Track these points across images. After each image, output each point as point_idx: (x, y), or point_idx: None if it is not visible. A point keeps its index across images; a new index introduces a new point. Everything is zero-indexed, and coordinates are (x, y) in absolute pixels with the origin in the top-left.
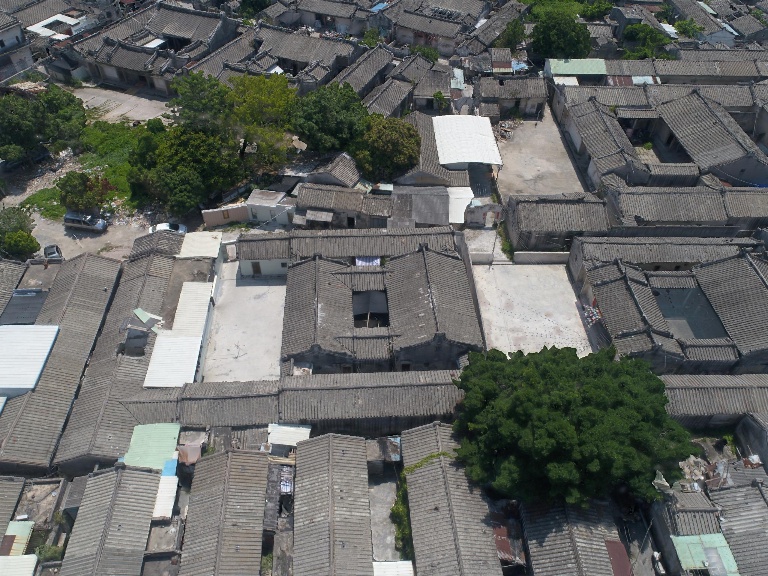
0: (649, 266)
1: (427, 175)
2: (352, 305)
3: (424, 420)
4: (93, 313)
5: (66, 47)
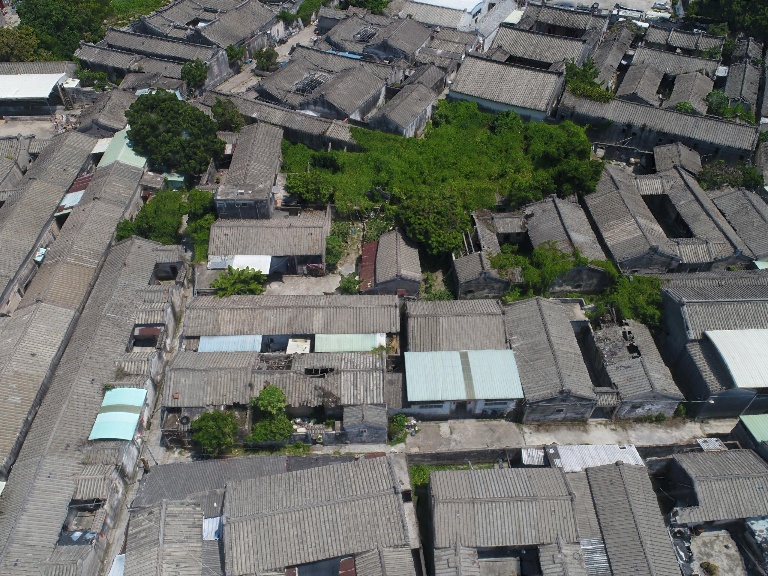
0: None
1: None
2: None
3: None
4: None
5: None
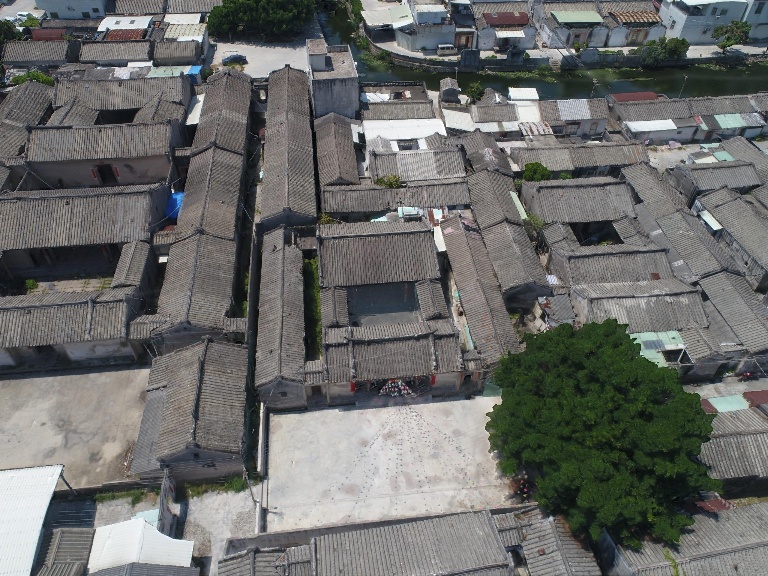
0: None
1: None
2: None
3: None
4: None
5: None
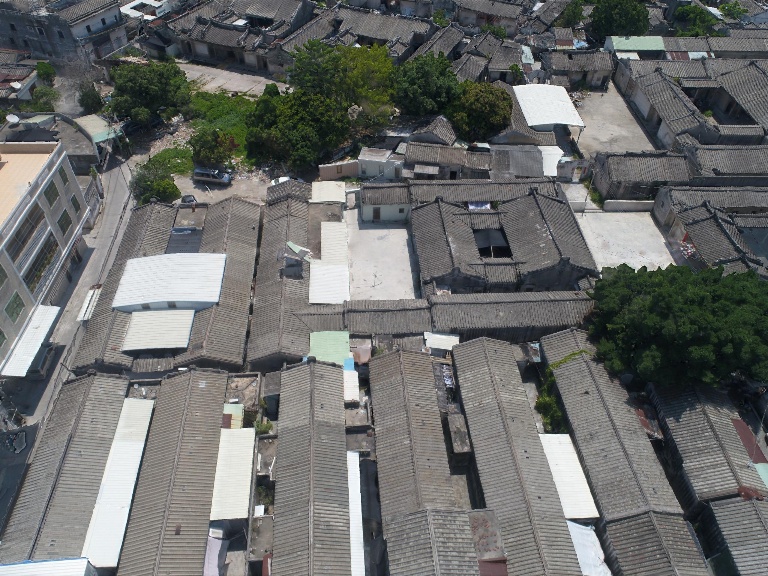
0: (728, 211)
1: (519, 134)
2: (474, 240)
3: (556, 331)
4: (248, 246)
5: (161, 25)
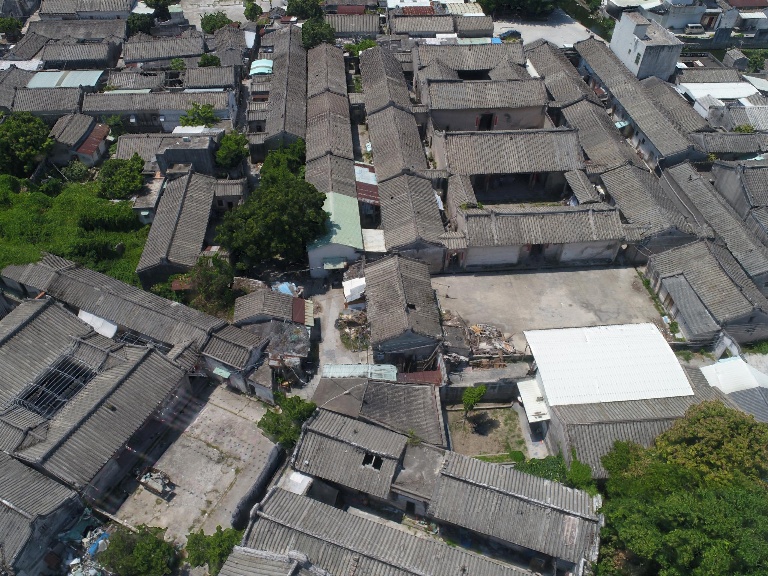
0: None
1: None
2: None
3: None
4: None
5: None
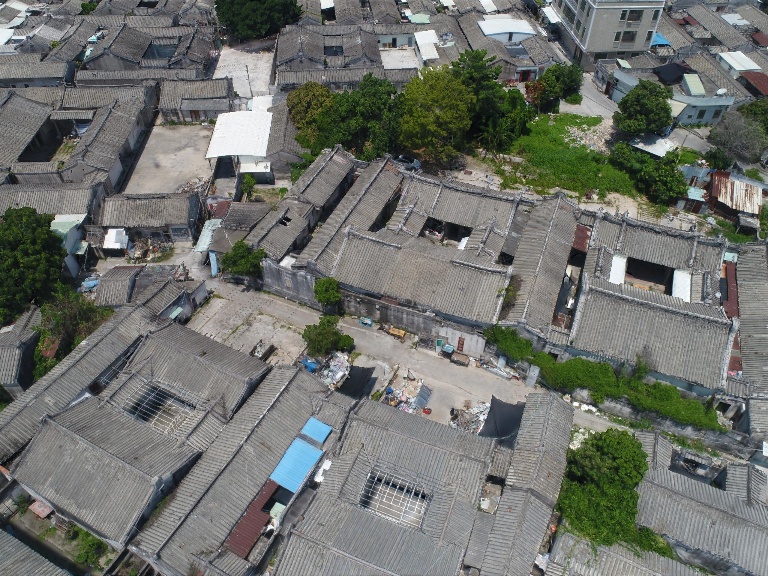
0: None
1: None
2: None
3: None
4: None
5: None
